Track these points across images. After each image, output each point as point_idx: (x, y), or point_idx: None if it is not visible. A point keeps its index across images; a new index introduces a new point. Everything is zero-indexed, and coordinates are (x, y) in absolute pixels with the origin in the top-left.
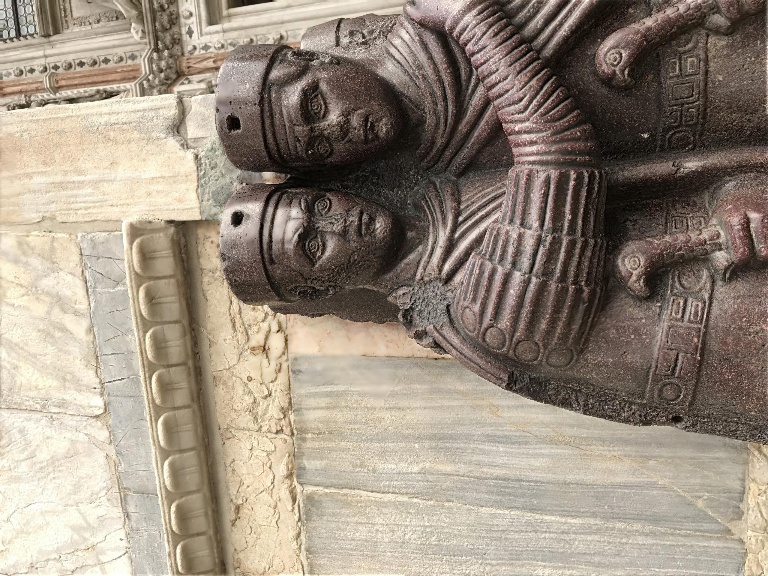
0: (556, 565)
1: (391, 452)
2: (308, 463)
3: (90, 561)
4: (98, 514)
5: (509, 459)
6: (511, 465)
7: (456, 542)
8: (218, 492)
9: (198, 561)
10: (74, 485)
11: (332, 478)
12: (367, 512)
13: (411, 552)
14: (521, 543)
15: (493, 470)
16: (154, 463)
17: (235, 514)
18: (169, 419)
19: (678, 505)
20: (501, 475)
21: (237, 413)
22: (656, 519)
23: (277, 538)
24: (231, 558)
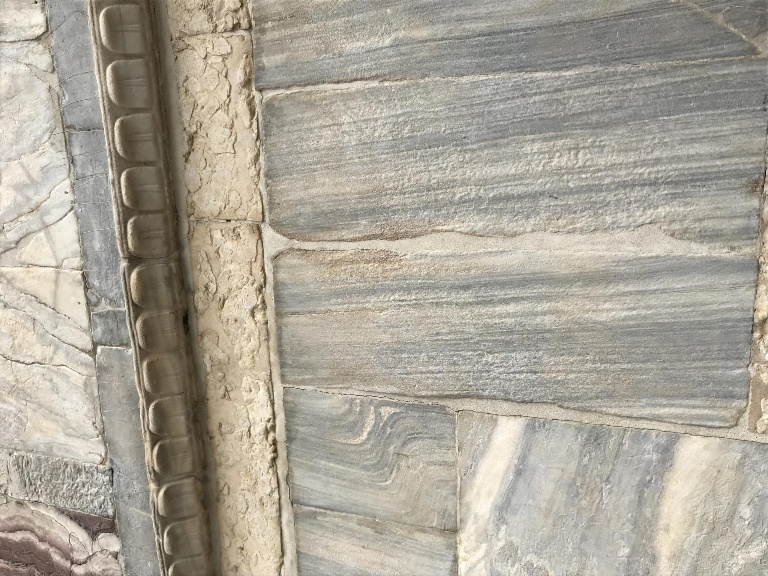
0: (547, 136)
1: (360, 25)
2: (267, 60)
3: (34, 226)
4: (42, 165)
5: (495, 5)
6: (497, 13)
7: (432, 129)
8: (170, 121)
9: (146, 196)
10: (16, 133)
11: (294, 74)
12: (332, 110)
13: (381, 153)
14: (507, 114)
15: (476, 24)
16: (96, 67)
17: (188, 145)
18: (112, 13)
19: (694, 27)
20: (485, 29)
21: (190, 13)
22: (667, 51)
23: (234, 166)
24: (184, 203)
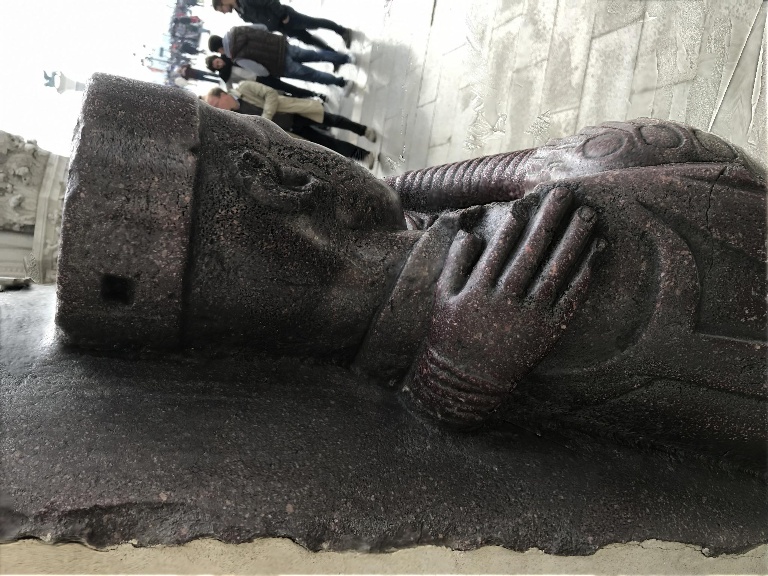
0: None
1: None
2: None
3: None
4: None
5: None
6: None
7: None
8: None
9: None
10: None
11: None
12: None
13: None
14: None
15: None
16: None
17: None
18: None
19: None
20: None
21: None
22: None
23: None
24: None
